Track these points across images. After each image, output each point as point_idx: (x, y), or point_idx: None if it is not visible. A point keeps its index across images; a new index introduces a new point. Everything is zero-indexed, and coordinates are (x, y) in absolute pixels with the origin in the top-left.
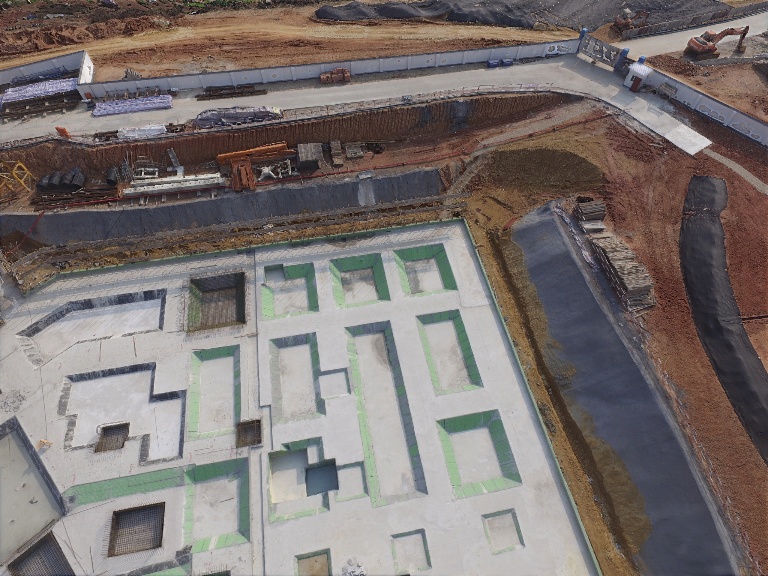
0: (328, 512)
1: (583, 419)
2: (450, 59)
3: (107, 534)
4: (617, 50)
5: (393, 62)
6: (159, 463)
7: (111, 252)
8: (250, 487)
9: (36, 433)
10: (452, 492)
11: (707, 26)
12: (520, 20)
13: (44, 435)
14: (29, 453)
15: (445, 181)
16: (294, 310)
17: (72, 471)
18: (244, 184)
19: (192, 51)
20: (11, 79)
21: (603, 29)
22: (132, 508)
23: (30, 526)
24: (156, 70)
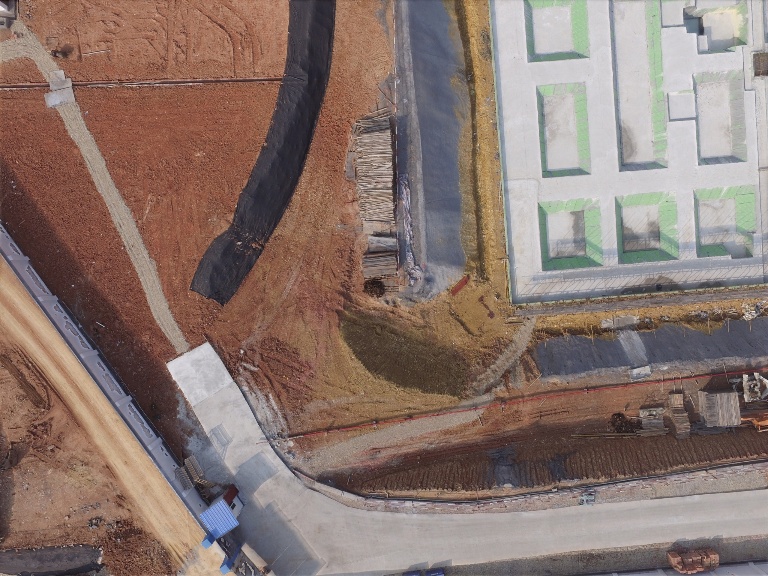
0: None
1: (455, 36)
2: None
3: None
4: (238, 573)
5: None
6: None
7: None
8: (763, 17)
9: None
10: None
11: None
12: None
13: None
14: None
15: (530, 362)
16: (714, 203)
17: None
18: None
19: None
20: None
21: None
22: None
23: None
24: None
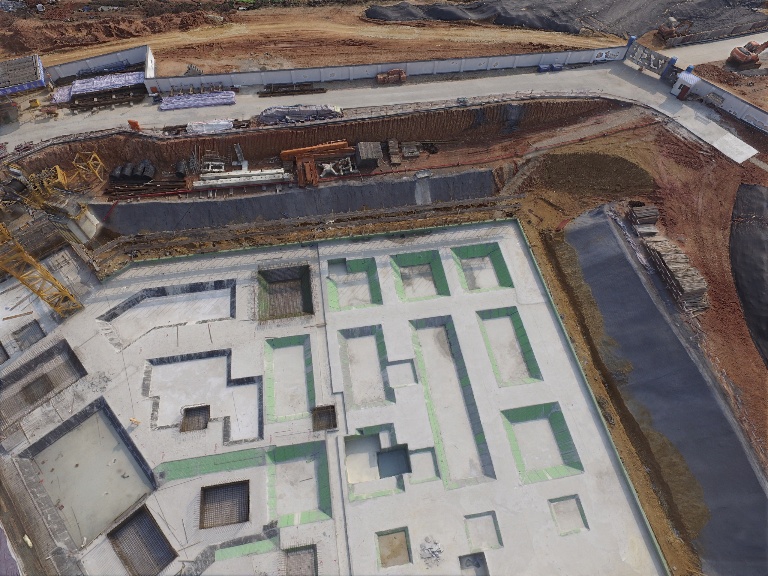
0: (404, 493)
1: (640, 413)
2: (502, 63)
3: (197, 508)
4: (665, 59)
5: (447, 64)
6: (242, 443)
7: (184, 242)
8: (329, 468)
9: (123, 412)
10: (519, 478)
11: (747, 36)
12: (566, 25)
13: (131, 414)
14: (117, 431)
15: (498, 182)
16: (358, 303)
17: (161, 449)
18: (308, 180)
19: (248, 48)
20: (77, 71)
21: (647, 36)
22: (219, 485)
23: (124, 499)
24: (216, 66)
